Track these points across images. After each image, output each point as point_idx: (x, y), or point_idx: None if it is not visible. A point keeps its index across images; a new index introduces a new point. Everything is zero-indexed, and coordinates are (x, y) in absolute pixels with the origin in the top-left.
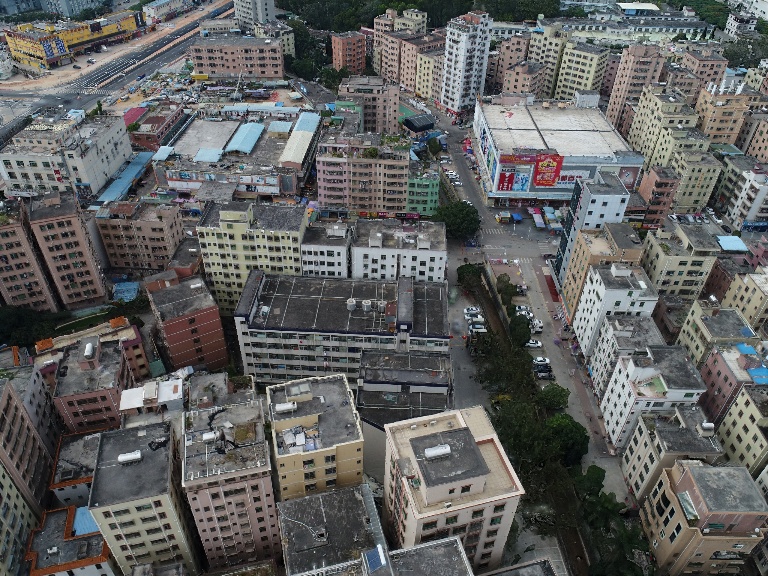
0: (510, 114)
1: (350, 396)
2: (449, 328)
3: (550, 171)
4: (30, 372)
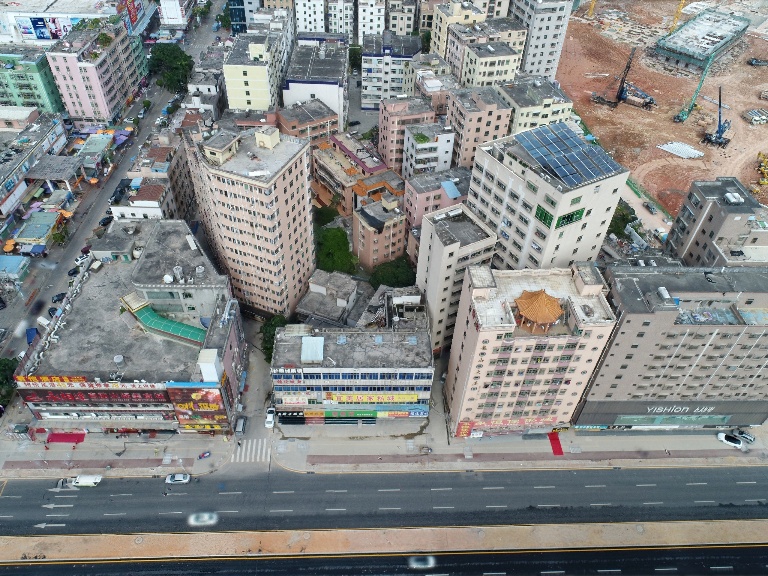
0: (14, 3)
1: (447, 4)
2: (343, 33)
3: (132, 7)
4: (412, 129)
